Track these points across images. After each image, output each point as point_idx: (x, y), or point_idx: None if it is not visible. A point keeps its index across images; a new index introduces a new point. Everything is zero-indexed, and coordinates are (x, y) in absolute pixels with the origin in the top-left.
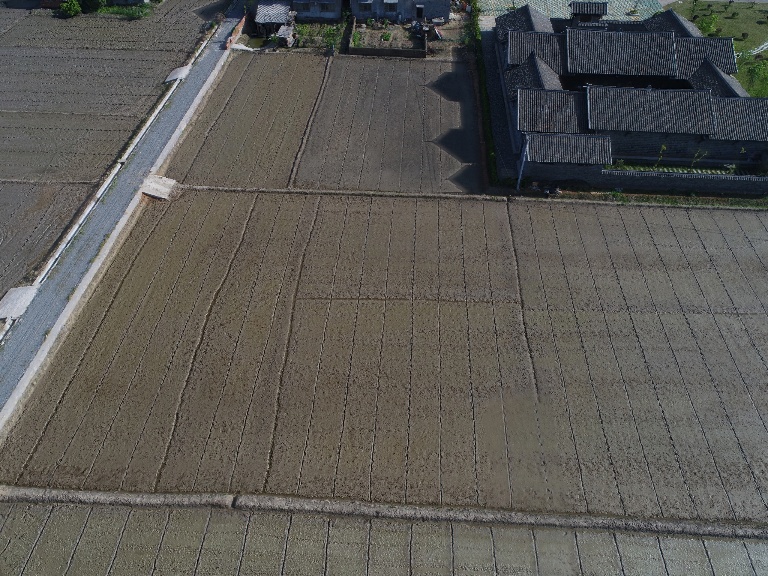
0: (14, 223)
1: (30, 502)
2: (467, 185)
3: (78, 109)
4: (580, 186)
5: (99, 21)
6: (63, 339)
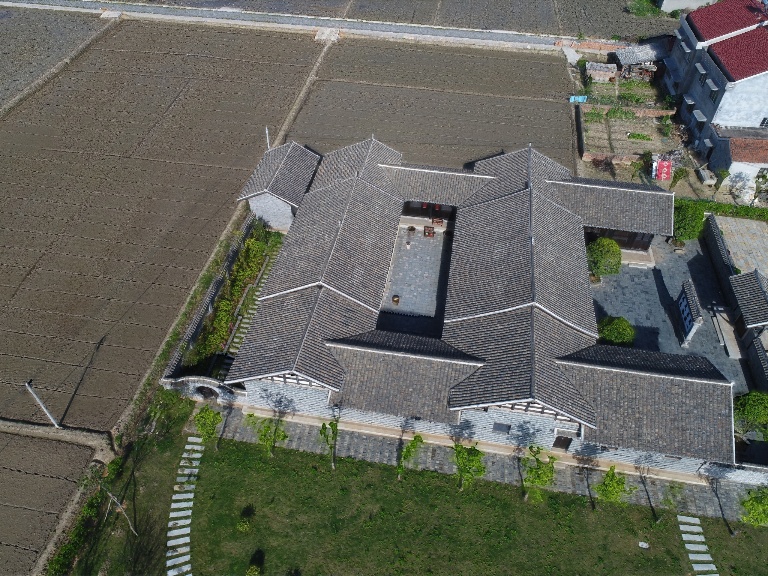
0: (306, 5)
1: None
2: None
3: (446, 7)
4: None
5: (617, 1)
6: (199, 24)
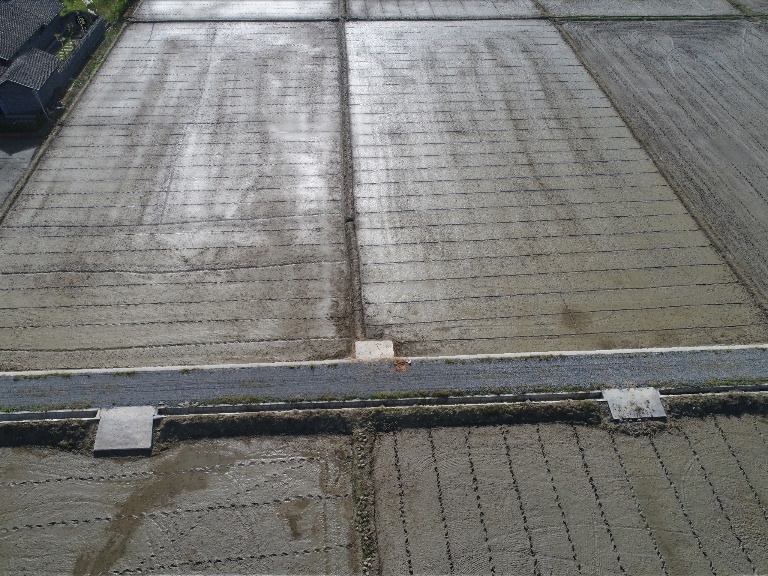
0: None
1: (364, 317)
2: (26, 145)
3: None
4: (60, 92)
5: None
6: None
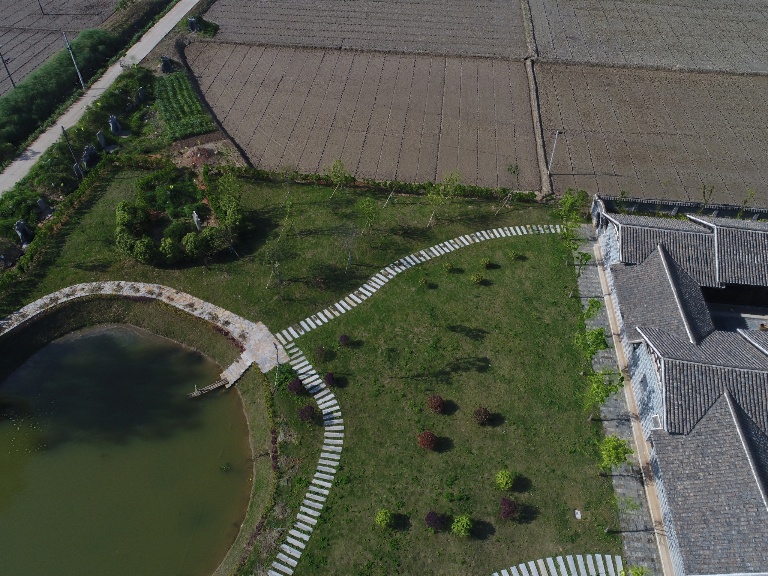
0: None
1: None
2: None
3: None
4: None
5: None
6: None
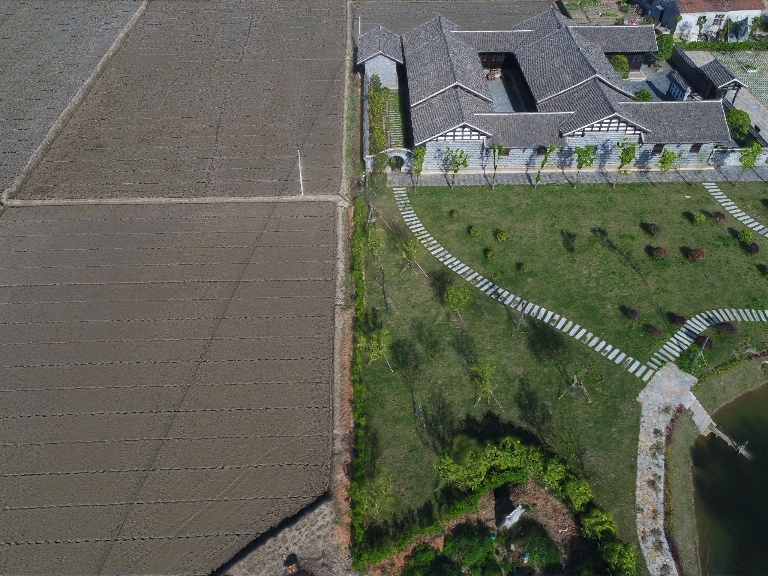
0: None
1: None
2: None
3: None
4: None
5: None
6: None
